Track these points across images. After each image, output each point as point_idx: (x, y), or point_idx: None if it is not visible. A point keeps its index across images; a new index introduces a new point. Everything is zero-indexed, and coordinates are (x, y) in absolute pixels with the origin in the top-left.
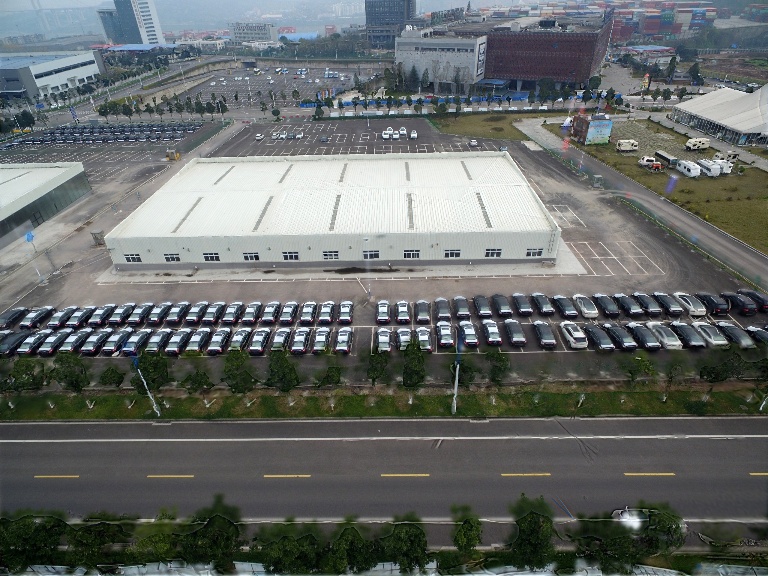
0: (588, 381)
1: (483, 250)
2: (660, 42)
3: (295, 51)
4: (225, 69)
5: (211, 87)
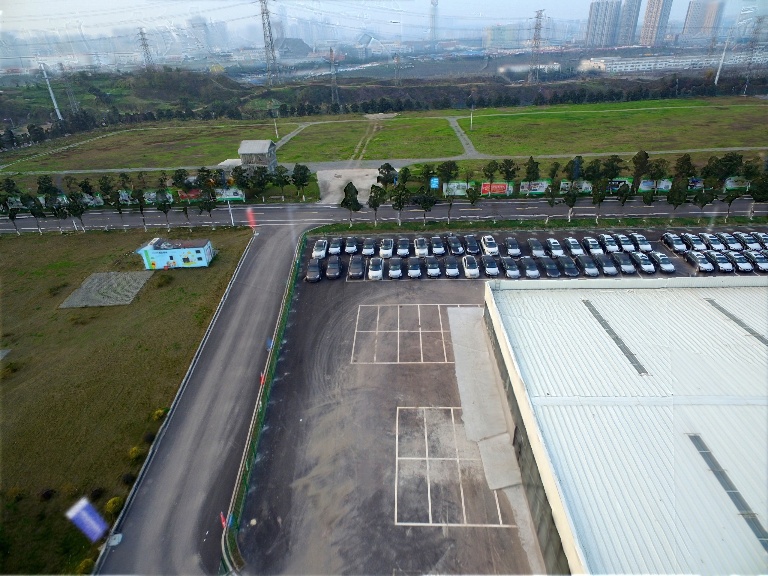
0: None
1: None
2: None
3: None
4: None
5: None
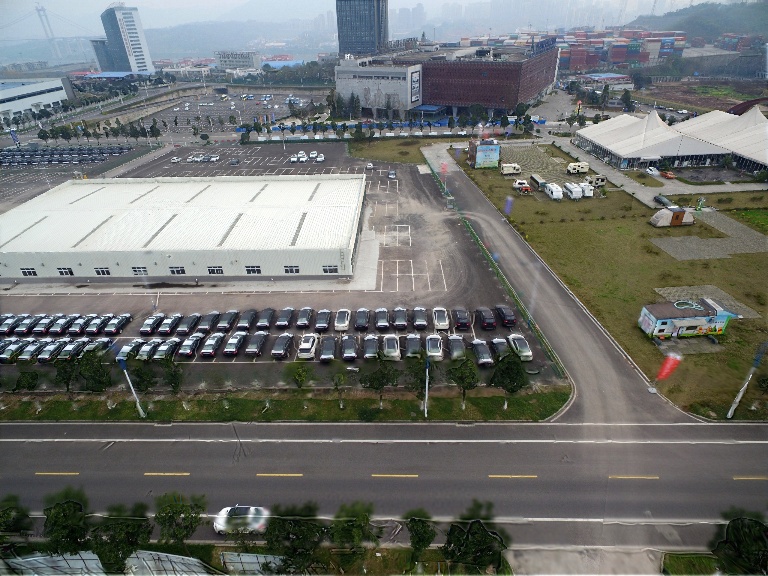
0: (291, 389)
1: (281, 267)
2: (624, 70)
3: (263, 78)
4: (196, 95)
5: (173, 112)
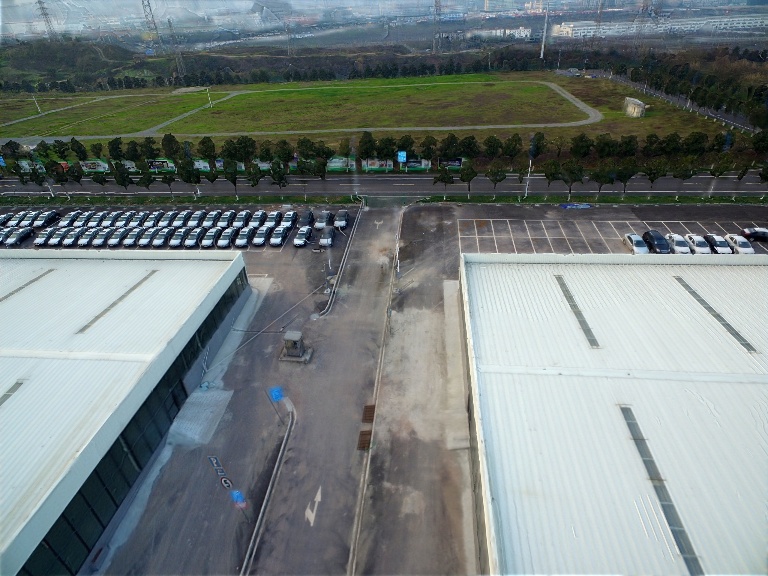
0: None
1: None
2: None
3: None
4: None
5: None
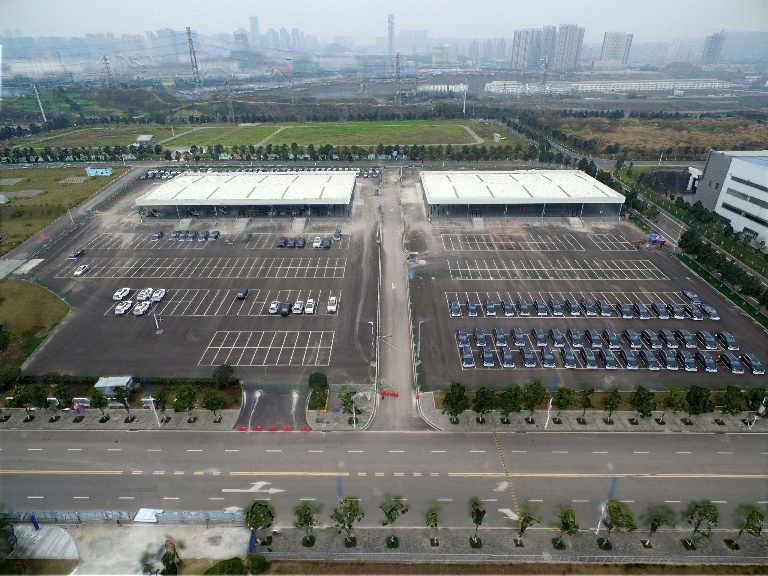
0: None
1: None
2: None
3: None
4: None
5: None
